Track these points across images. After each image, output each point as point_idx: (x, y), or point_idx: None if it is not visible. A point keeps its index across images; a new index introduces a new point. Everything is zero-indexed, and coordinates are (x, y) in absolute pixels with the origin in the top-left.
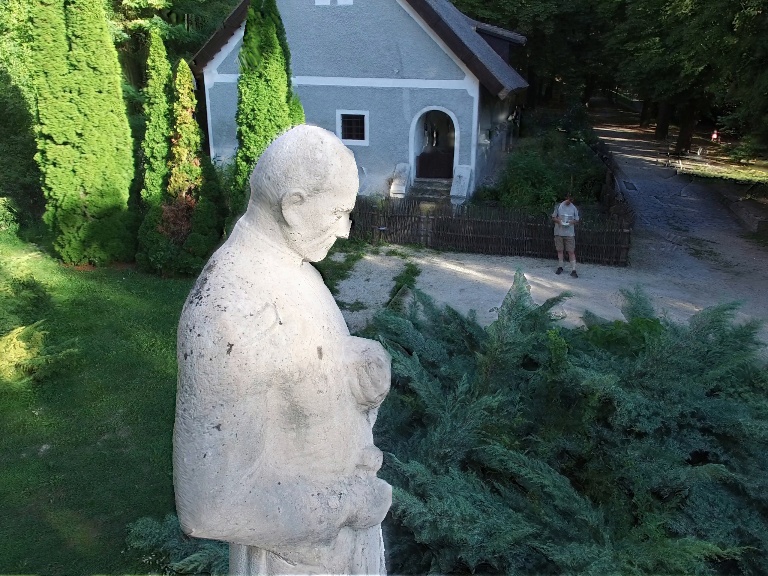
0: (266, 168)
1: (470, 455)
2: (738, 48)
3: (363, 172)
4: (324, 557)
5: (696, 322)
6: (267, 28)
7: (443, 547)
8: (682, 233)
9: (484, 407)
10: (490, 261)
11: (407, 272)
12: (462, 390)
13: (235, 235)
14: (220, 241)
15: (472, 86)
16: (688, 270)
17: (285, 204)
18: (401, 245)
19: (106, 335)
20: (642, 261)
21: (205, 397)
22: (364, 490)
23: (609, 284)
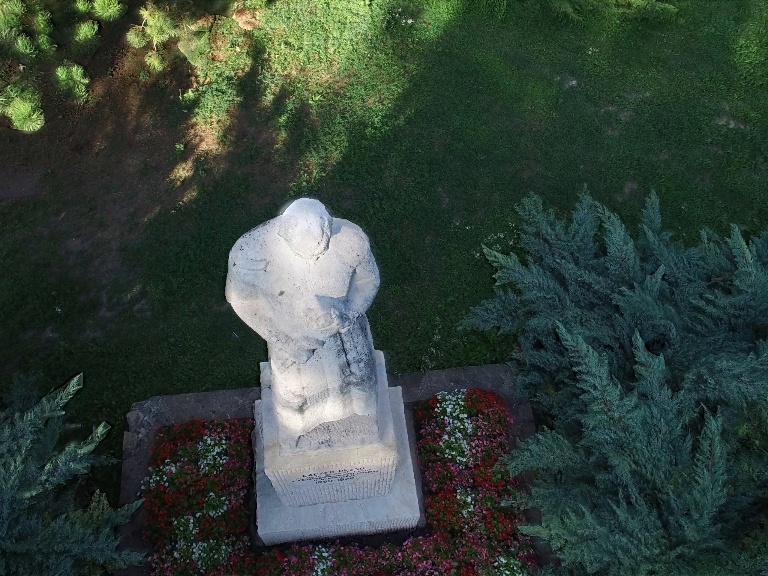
0: None
1: (720, 403)
2: None
3: None
4: (275, 348)
5: None
6: None
7: None
8: None
9: None
10: None
11: None
12: None
13: None
14: None
15: None
16: None
17: None
18: None
19: (730, 4)
20: None
21: None
22: (293, 348)
23: None
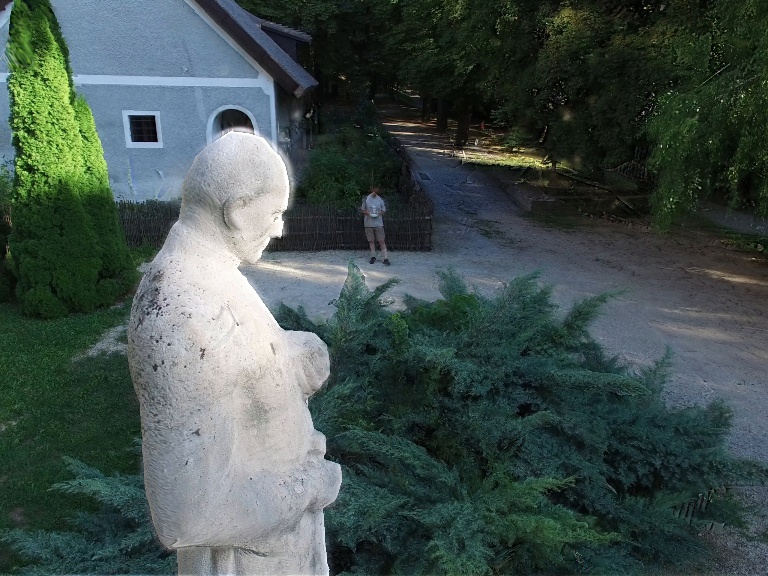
0: (203, 176)
1: (330, 444)
2: (501, 50)
3: (160, 176)
4: (291, 544)
5: (508, 293)
6: (38, 22)
7: None
8: (473, 216)
9: (337, 396)
10: (306, 257)
11: None
12: None
13: (173, 245)
14: (3, 262)
15: (267, 84)
16: (482, 249)
17: (228, 210)
18: None
19: None
20: (443, 245)
21: (182, 406)
22: (319, 474)
23: (419, 268)
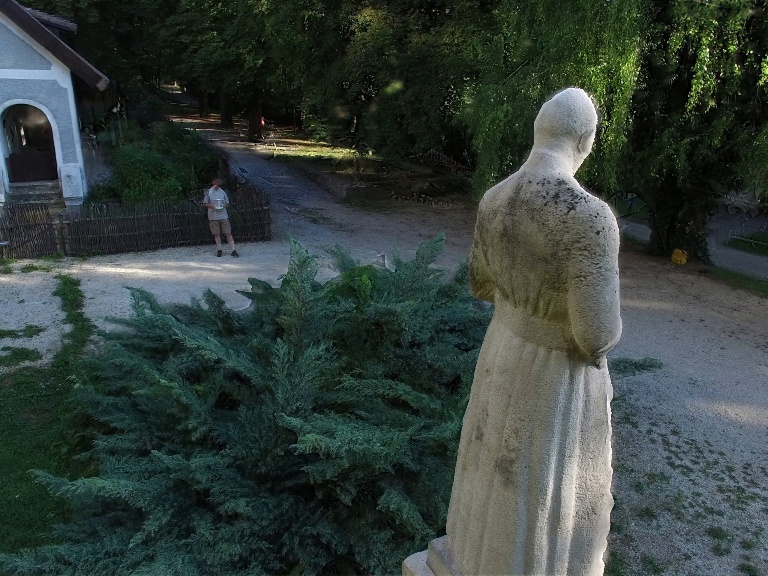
0: (572, 116)
1: (317, 402)
2: (309, 44)
3: None
4: None
5: (421, 255)
6: None
7: (354, 471)
8: (299, 205)
9: (315, 358)
10: (147, 257)
11: (65, 284)
12: (284, 352)
13: (552, 163)
14: None
15: (63, 77)
16: (318, 235)
17: None
18: (33, 259)
19: None
20: (279, 234)
21: None
22: None
23: (269, 257)
